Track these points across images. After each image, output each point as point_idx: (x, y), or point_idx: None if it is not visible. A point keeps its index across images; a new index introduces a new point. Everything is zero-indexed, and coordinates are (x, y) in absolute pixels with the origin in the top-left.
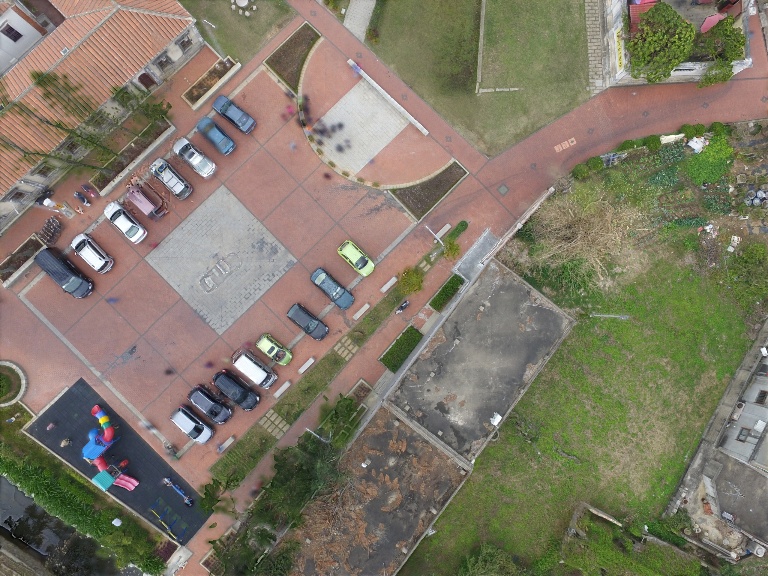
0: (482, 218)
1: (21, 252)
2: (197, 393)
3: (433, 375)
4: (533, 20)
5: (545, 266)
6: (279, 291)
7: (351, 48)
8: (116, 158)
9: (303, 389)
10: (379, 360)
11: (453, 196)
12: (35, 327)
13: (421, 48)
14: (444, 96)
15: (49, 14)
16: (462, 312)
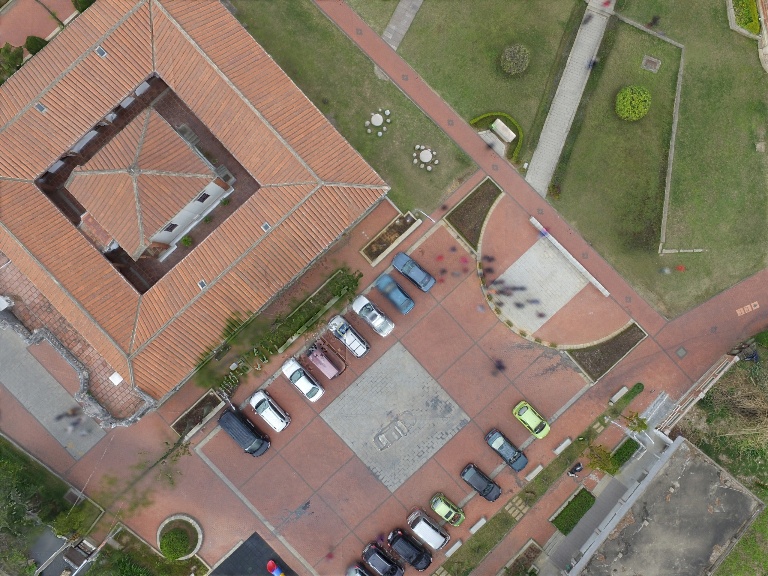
0: (658, 381)
1: (199, 407)
2: (375, 556)
3: (621, 556)
4: (722, 180)
5: (723, 433)
6: (452, 450)
7: (532, 204)
8: (294, 314)
9: (473, 548)
10: (550, 521)
11: (630, 358)
12: (211, 481)
13: (604, 205)
14: (625, 255)
15: (228, 165)
16: (651, 493)
